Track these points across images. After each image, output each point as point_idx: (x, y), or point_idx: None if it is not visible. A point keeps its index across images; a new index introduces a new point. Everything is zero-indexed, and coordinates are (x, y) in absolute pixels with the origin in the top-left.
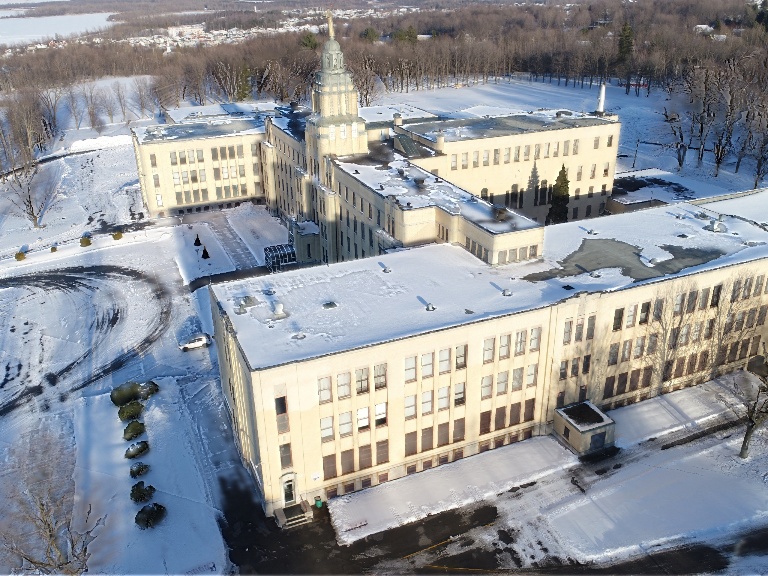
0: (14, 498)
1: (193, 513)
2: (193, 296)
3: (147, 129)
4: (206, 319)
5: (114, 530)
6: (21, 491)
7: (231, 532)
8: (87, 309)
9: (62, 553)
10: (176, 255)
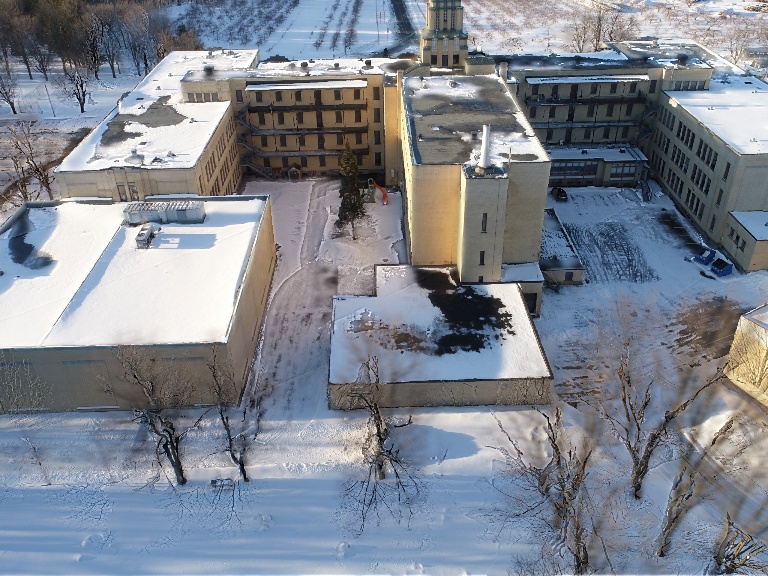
0: None
1: None
2: None
3: (686, 43)
4: None
5: None
6: None
7: None
8: None
9: None
10: None
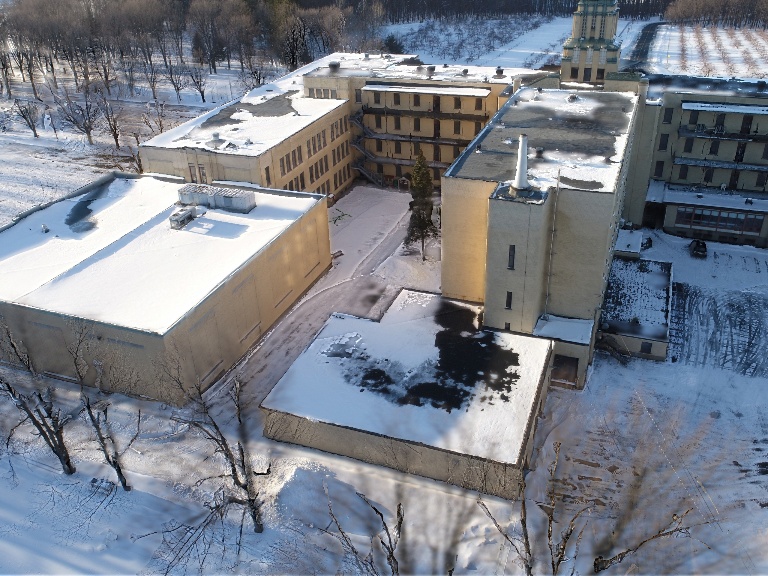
0: None
1: None
2: None
3: None
4: None
5: None
6: None
7: None
8: None
9: None
10: None
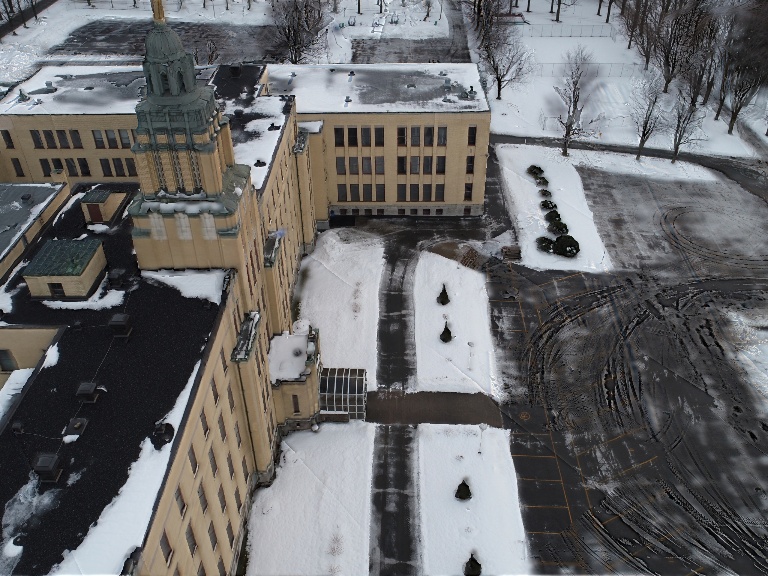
0: (629, 214)
1: (511, 165)
2: (498, 387)
3: None
4: (485, 330)
5: (556, 176)
6: (627, 217)
7: (492, 155)
8: (664, 430)
9: (584, 177)
10: (525, 560)
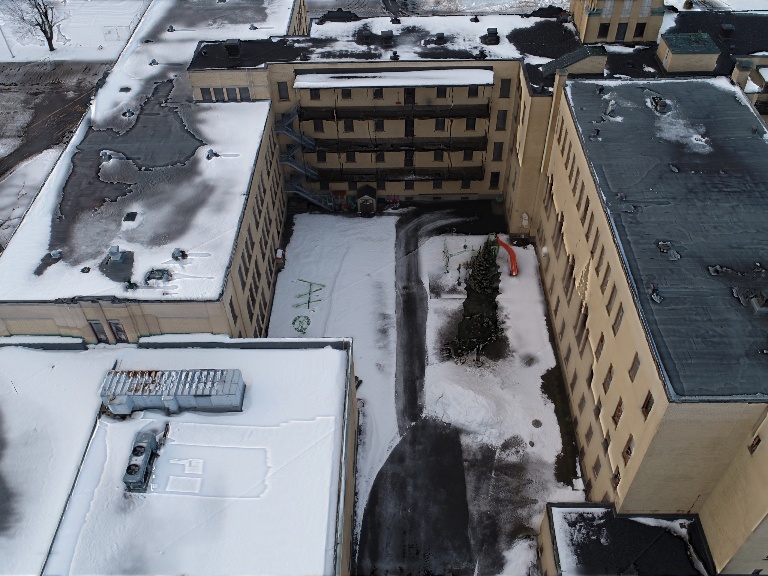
0: None
1: None
2: None
3: None
4: None
5: None
6: None
7: None
8: None
9: None
10: None
